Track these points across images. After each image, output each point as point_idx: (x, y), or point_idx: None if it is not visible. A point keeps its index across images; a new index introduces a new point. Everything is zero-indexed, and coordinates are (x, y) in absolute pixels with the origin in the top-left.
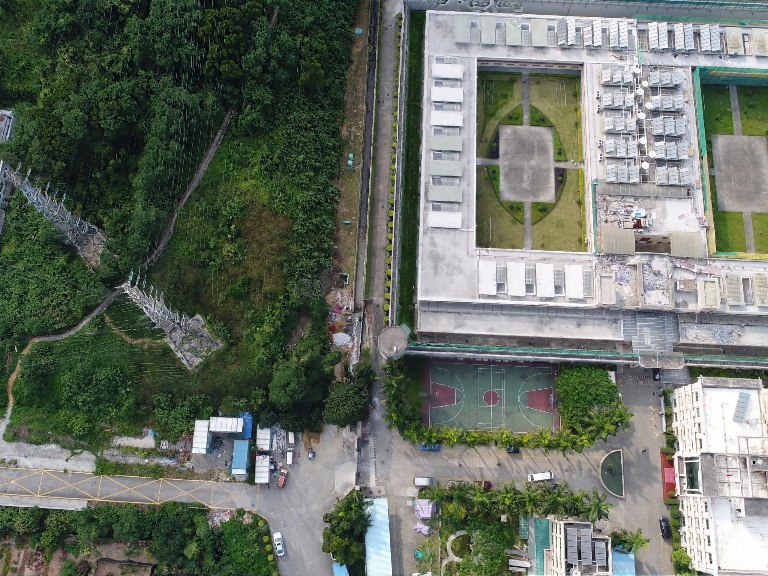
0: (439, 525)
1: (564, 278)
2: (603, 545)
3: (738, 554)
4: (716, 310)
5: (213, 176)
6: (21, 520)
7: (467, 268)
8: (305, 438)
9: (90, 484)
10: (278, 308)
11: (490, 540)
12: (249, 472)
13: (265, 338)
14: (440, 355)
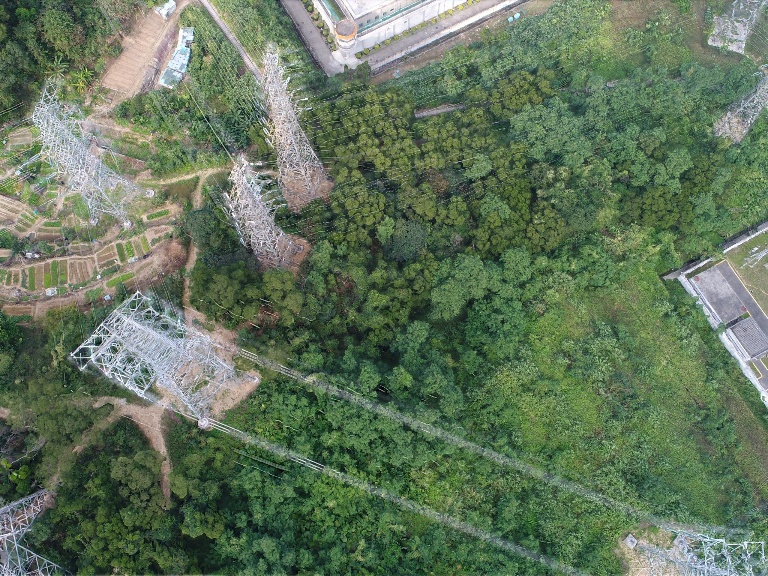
0: None
1: None
2: None
3: None
4: None
5: (620, 68)
6: None
7: None
8: None
9: None
10: None
11: None
12: None
13: None
14: None
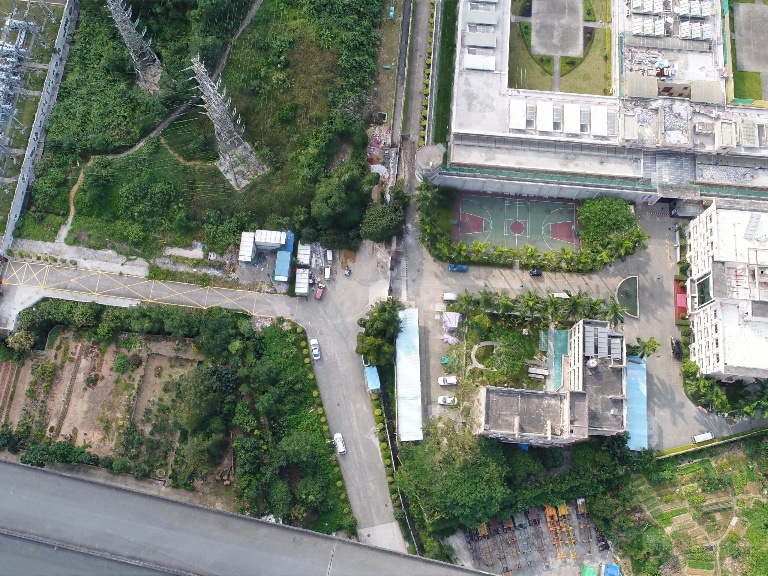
0: (465, 330)
1: (590, 118)
2: (618, 341)
3: (744, 352)
4: (732, 151)
5: (265, 14)
6: (80, 311)
7: (499, 106)
8: (342, 257)
9: (143, 287)
10: (322, 131)
11: (513, 343)
12: (289, 285)
13: (309, 159)
14: (470, 187)
